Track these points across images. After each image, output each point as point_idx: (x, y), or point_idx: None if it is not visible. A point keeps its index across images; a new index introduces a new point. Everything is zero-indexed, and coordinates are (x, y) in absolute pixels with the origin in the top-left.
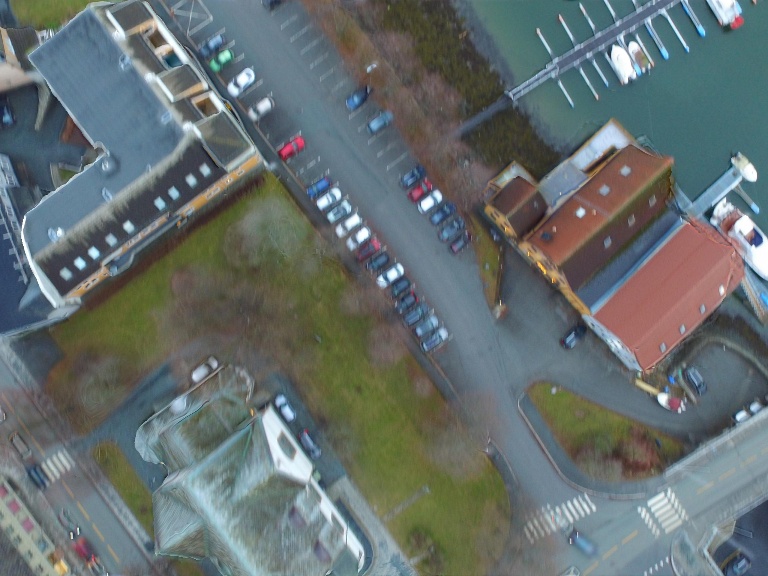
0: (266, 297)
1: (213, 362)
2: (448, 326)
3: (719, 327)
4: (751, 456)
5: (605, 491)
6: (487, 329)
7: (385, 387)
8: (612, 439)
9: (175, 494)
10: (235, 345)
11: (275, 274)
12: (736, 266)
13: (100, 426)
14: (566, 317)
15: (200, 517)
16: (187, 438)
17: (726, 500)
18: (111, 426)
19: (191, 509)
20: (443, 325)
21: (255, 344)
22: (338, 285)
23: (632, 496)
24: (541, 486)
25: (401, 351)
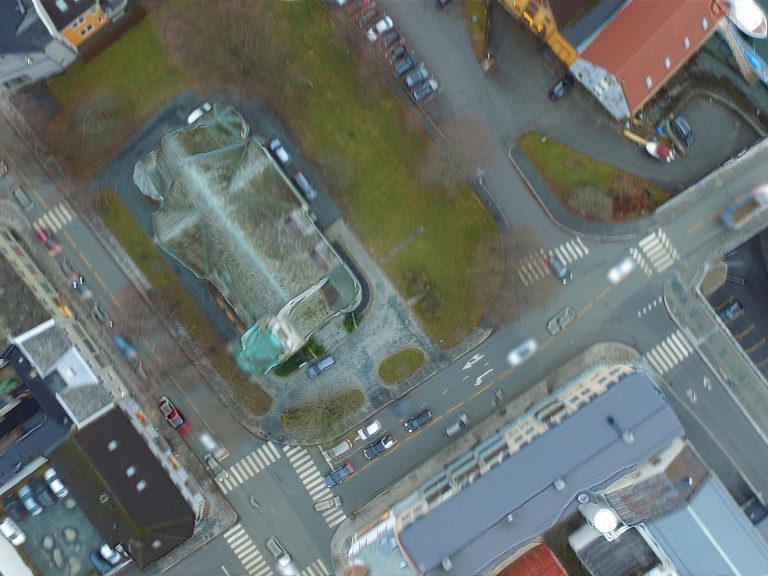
0: (258, 40)
1: (208, 108)
2: (438, 78)
3: (705, 84)
4: (740, 194)
5: (597, 234)
6: (476, 81)
7: (377, 132)
8: (603, 187)
9: (173, 199)
10: (229, 92)
11: (266, 13)
12: (720, 22)
13: (100, 176)
14: (554, 71)
15: (198, 209)
16: (183, 145)
17: (716, 239)
18: (110, 175)
19: (189, 205)
20: (433, 77)
21: (249, 90)
22: (328, 33)
23: (624, 237)
24: (534, 231)
25: (392, 99)
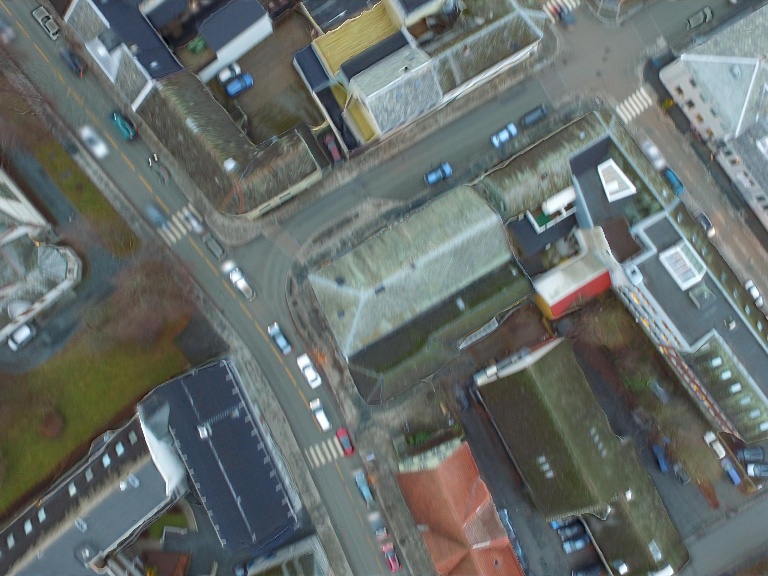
0: None
1: (13, 345)
2: None
3: None
4: None
5: None
6: None
7: None
8: None
9: None
10: None
11: None
12: None
13: (132, 272)
14: None
15: None
16: None
17: None
18: (120, 272)
19: None
20: None
21: None
22: None
23: None
24: None
25: None
